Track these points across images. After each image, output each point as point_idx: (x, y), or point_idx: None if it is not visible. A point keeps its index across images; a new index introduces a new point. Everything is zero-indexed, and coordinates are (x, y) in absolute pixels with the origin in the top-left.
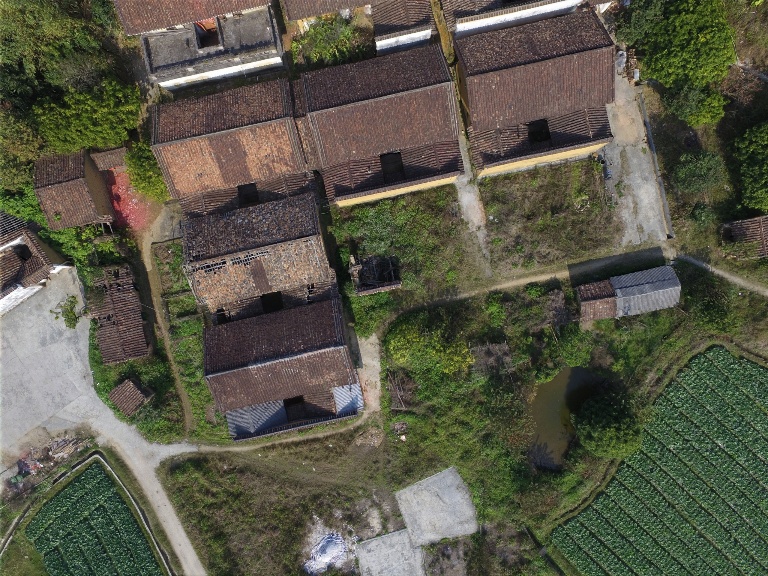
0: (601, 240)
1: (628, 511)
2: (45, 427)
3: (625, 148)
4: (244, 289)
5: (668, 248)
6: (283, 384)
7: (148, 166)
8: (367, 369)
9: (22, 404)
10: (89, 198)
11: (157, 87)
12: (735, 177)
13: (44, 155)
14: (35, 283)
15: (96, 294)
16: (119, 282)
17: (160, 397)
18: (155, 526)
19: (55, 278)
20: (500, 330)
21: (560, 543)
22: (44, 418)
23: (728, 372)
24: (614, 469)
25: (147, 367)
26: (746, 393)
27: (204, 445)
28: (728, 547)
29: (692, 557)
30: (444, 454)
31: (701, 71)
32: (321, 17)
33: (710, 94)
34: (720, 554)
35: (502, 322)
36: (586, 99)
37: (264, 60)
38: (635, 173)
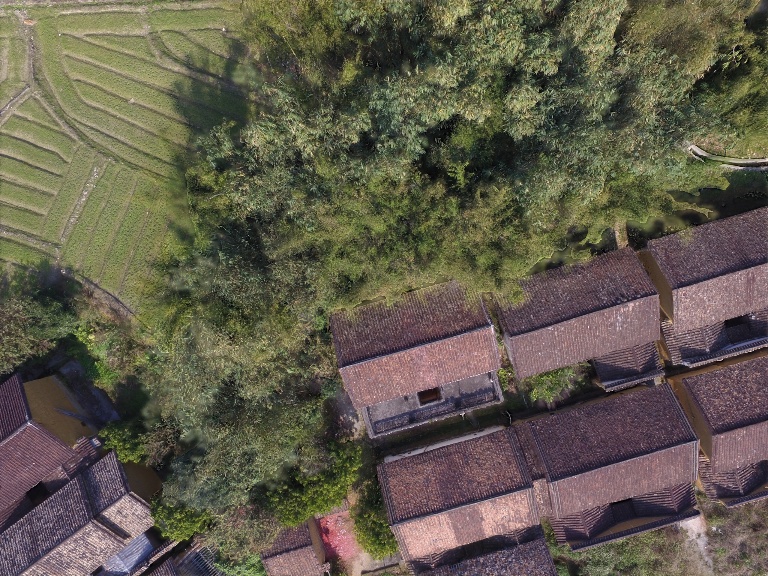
0: None
1: None
2: None
3: None
4: None
5: None
6: None
7: (388, 545)
8: None
9: None
10: (316, 562)
11: (362, 420)
12: None
13: None
14: None
15: None
16: None
17: None
18: None
19: None
20: None
21: None
22: None
23: None
24: None
25: None
26: None
27: None
28: None
29: None
30: None
31: None
32: None
33: None
34: None
35: None
36: None
37: None
38: None
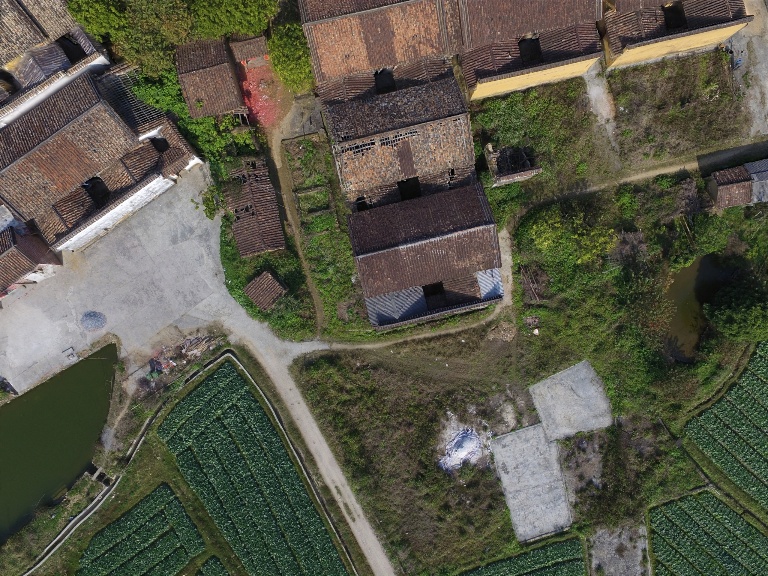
0: (731, 130)
1: (762, 401)
2: (177, 326)
3: (752, 39)
4: (389, 173)
5: None
6: (430, 267)
7: (300, 45)
8: None
9: (153, 303)
10: (232, 84)
11: None
12: None
13: (190, 39)
14: None
15: (235, 184)
16: (257, 173)
17: (293, 293)
18: (289, 424)
19: (186, 175)
20: (631, 222)
21: (695, 435)
22: (176, 317)
23: None
24: (746, 360)
25: (283, 260)
26: None
27: (336, 343)
28: None
29: None
30: (577, 347)
31: None
32: None
33: None
34: None
35: (634, 212)
36: None
37: None
38: (762, 63)
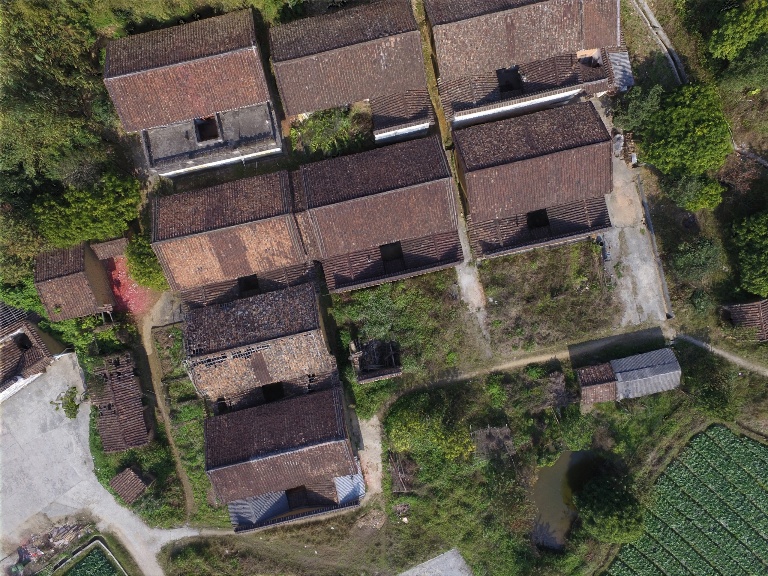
0: (601, 321)
1: None
2: (46, 513)
3: (623, 229)
4: (245, 381)
5: (668, 328)
6: (284, 476)
7: (148, 263)
8: (368, 451)
9: (22, 490)
10: (89, 291)
11: None
12: (733, 258)
13: (44, 250)
14: None
15: (96, 384)
16: (119, 371)
17: (161, 482)
18: None
19: (55, 363)
20: (501, 411)
21: None
22: (44, 504)
23: (729, 451)
24: (617, 549)
25: (148, 454)
26: (748, 471)
27: (205, 529)
28: None
29: None
30: (446, 536)
31: (698, 162)
32: (320, 111)
33: (707, 183)
34: None
35: (503, 404)
36: (584, 190)
37: (263, 151)
38: (634, 254)
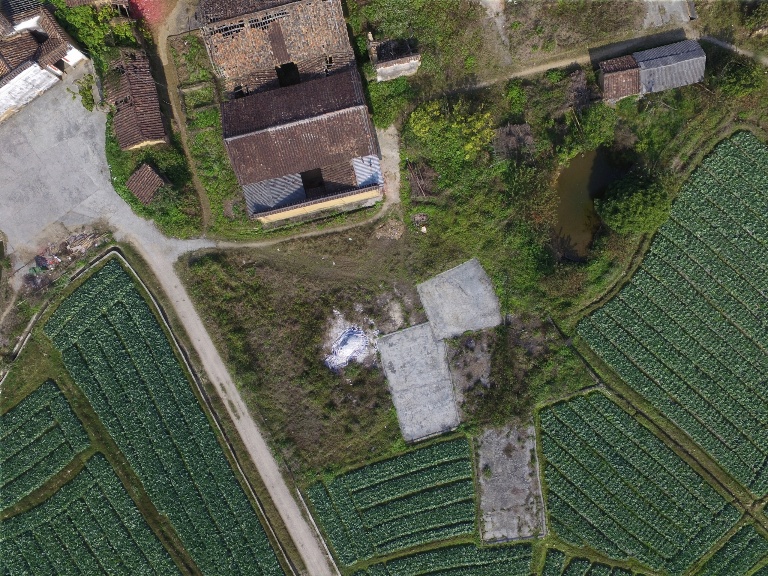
0: (622, 21)
1: (655, 300)
2: (62, 222)
3: None
4: (262, 57)
5: (691, 29)
6: (303, 152)
7: None
8: (386, 160)
9: (39, 199)
10: None
11: None
12: None
13: None
14: (52, 64)
15: (113, 75)
16: (136, 65)
17: None
18: (174, 321)
19: (71, 72)
20: (521, 118)
21: (586, 334)
22: (61, 213)
23: (755, 157)
24: (640, 258)
25: (164, 154)
26: None
27: (222, 241)
28: (759, 335)
29: (722, 345)
30: (466, 245)
31: None
32: None
33: None
34: (751, 342)
35: (523, 106)
36: None
37: None
38: None
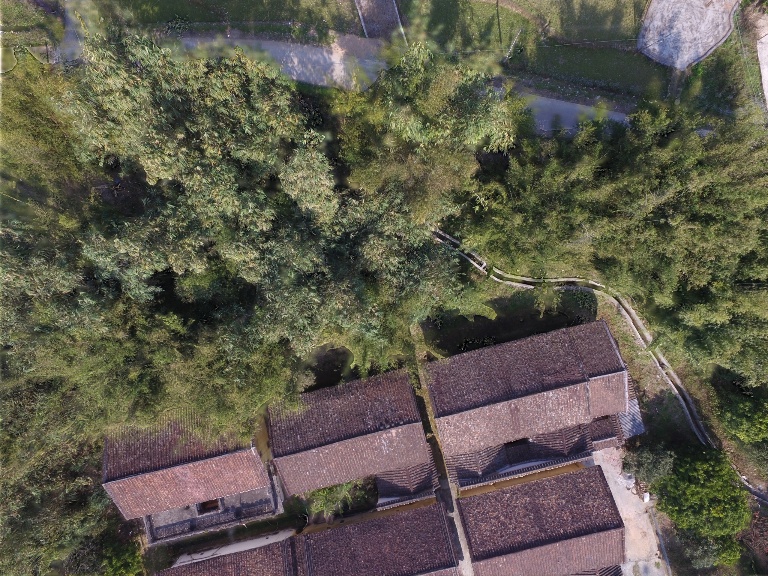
0: None
1: None
2: None
3: (638, 563)
4: None
5: None
6: None
7: None
8: None
9: None
10: None
11: None
12: None
13: None
14: None
15: None
16: None
17: None
18: None
19: None
20: None
21: None
22: None
23: None
24: None
25: None
26: None
27: None
28: None
29: None
30: None
31: None
32: None
33: (725, 548)
34: None
35: None
36: (596, 563)
37: None
38: None
